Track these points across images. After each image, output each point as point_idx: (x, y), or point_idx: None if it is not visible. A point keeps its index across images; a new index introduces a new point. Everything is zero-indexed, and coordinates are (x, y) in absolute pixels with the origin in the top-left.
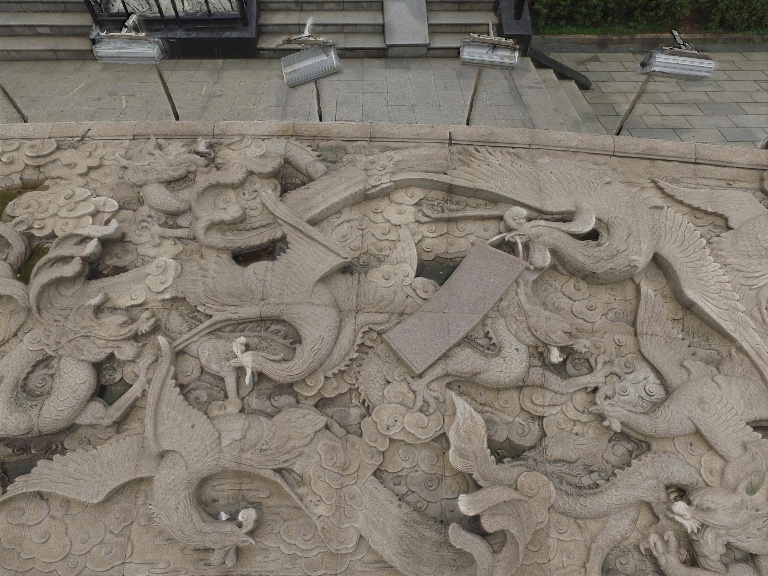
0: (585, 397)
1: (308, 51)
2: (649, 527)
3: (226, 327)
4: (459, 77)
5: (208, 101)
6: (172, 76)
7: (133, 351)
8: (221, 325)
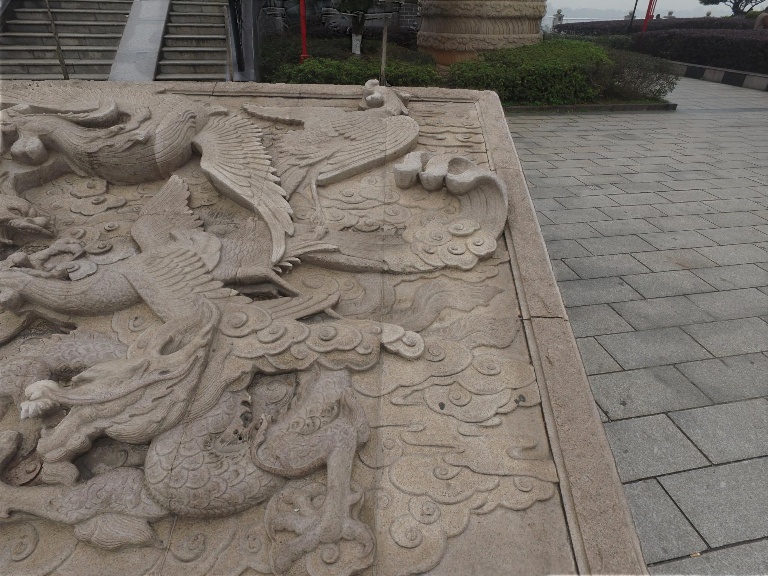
0: None
1: None
2: None
3: None
4: None
5: None
6: None
7: None
8: None
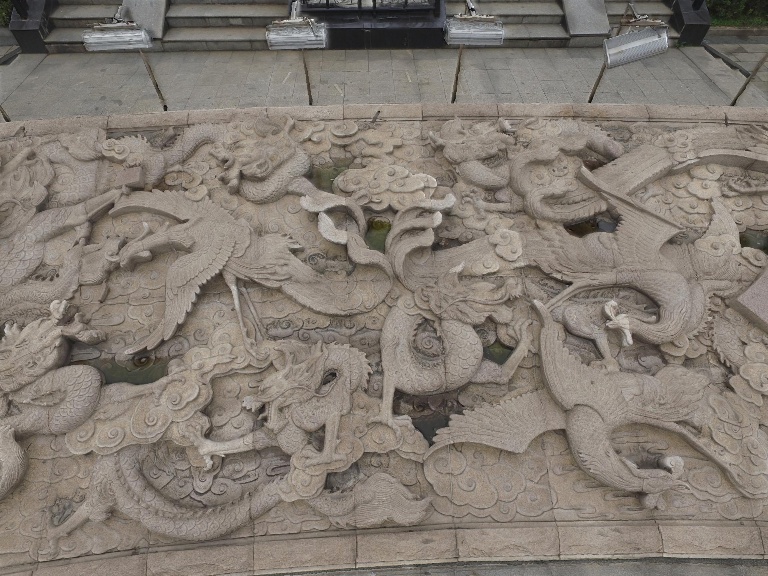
0: None
1: (638, 33)
2: None
3: (580, 293)
4: (646, 66)
5: (419, 88)
6: (371, 65)
7: (511, 315)
8: (579, 291)
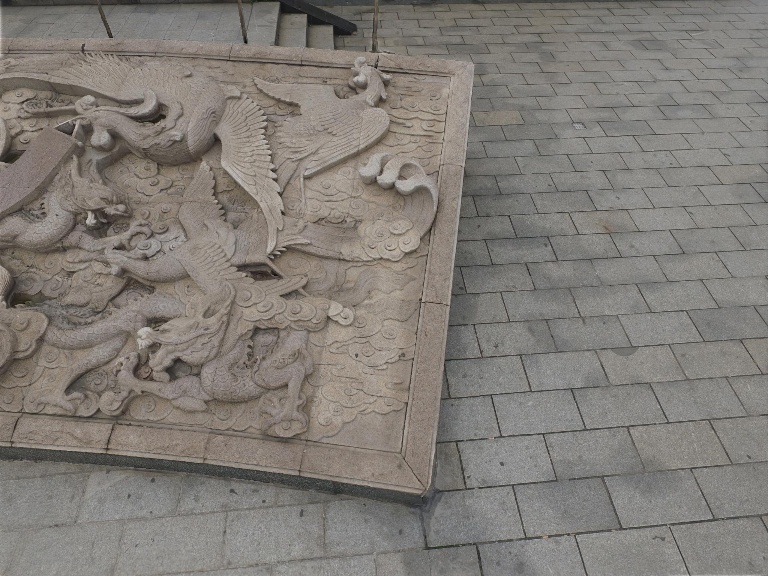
0: None
1: None
2: None
3: None
4: (198, 18)
5: None
6: None
7: None
8: None
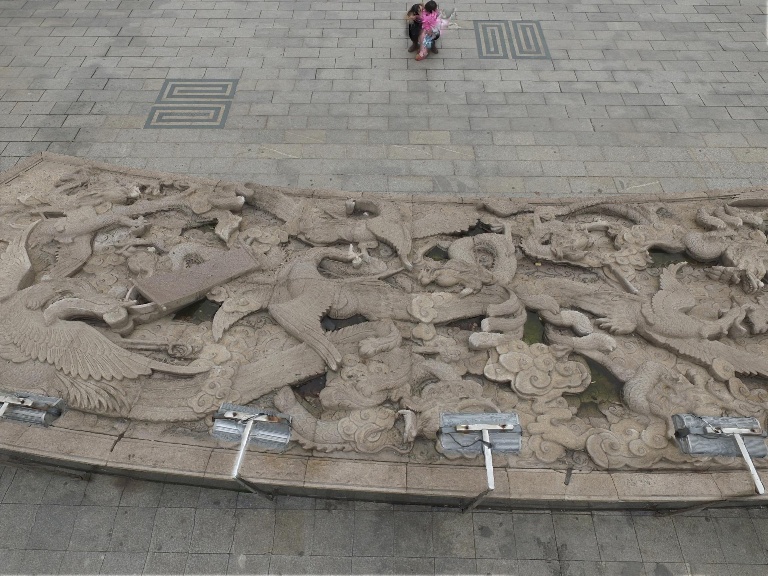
0: None
1: None
2: (154, 199)
3: None
4: None
5: None
6: None
7: (428, 264)
8: None
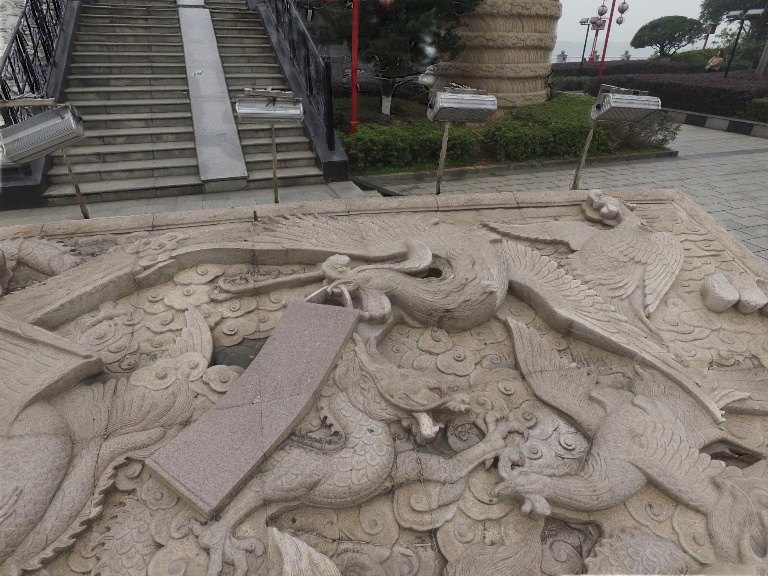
0: (486, 478)
1: (37, 116)
2: None
3: None
4: (283, 199)
5: None
6: None
7: None
8: None
